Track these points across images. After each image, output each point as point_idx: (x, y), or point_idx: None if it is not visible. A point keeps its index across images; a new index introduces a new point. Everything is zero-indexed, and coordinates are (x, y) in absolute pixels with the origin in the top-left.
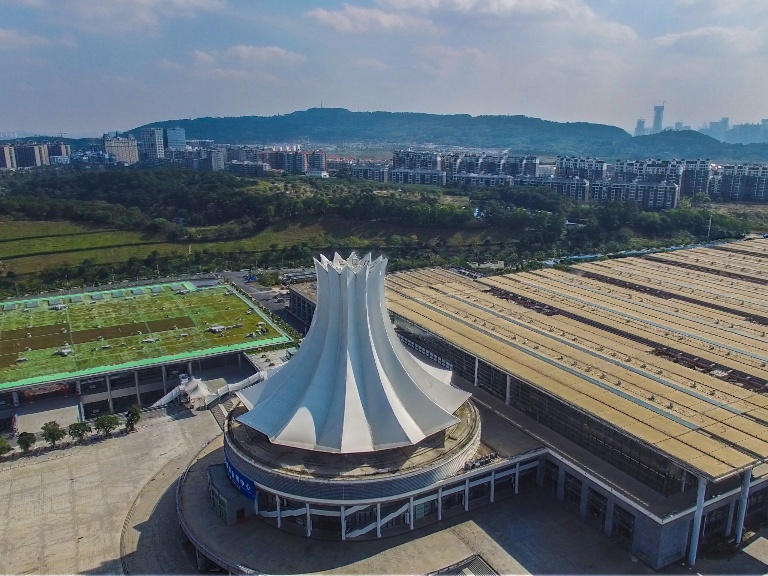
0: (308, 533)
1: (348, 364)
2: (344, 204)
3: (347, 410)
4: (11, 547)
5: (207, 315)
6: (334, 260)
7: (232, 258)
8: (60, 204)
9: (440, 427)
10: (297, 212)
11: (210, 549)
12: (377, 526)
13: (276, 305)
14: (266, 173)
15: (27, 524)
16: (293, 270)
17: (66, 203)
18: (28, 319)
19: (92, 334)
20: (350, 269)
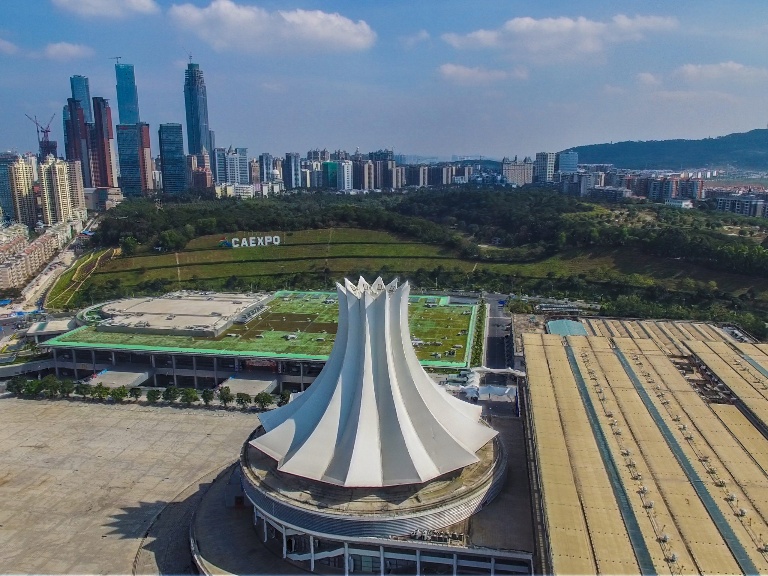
0: (265, 539)
1: (337, 388)
2: (643, 237)
3: (316, 432)
4: (130, 467)
5: (423, 329)
6: (374, 284)
7: (508, 281)
8: (385, 217)
9: (400, 481)
10: (592, 241)
11: (194, 518)
12: (311, 558)
13: (500, 332)
14: (624, 199)
15: (154, 455)
16: (556, 301)
17: (390, 216)
18: (300, 307)
19: (324, 327)
20: (351, 293)
